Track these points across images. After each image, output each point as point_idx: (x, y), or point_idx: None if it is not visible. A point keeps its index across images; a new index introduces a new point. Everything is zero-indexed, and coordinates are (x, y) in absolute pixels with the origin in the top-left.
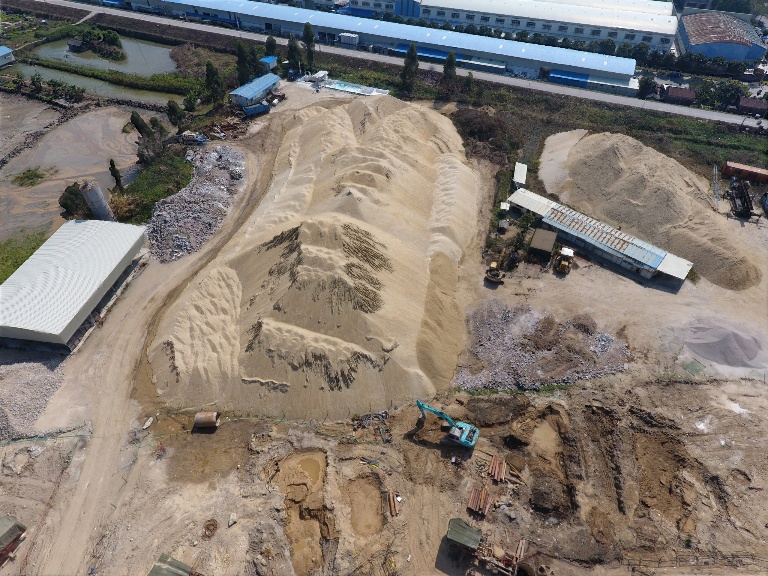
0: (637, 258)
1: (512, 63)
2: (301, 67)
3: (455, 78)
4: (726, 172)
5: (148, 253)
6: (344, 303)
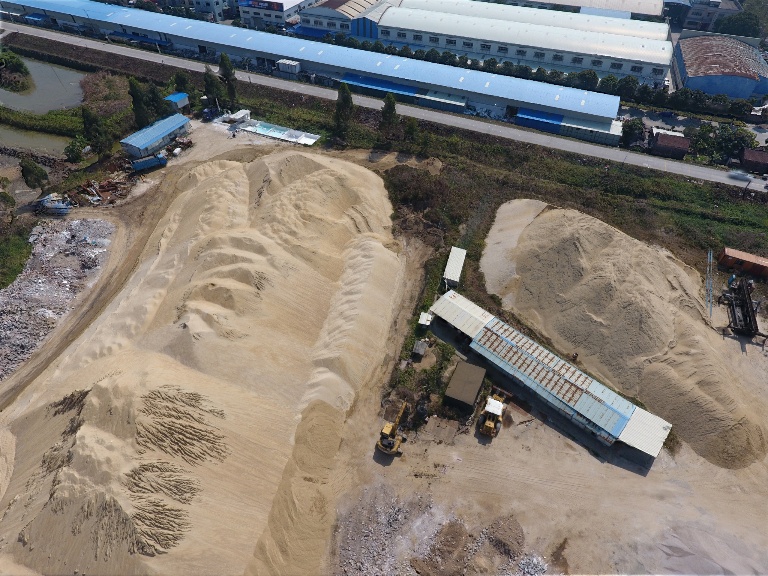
0: (592, 418)
1: (474, 99)
2: (223, 103)
3: (397, 123)
4: (724, 262)
5: None
6: (115, 542)
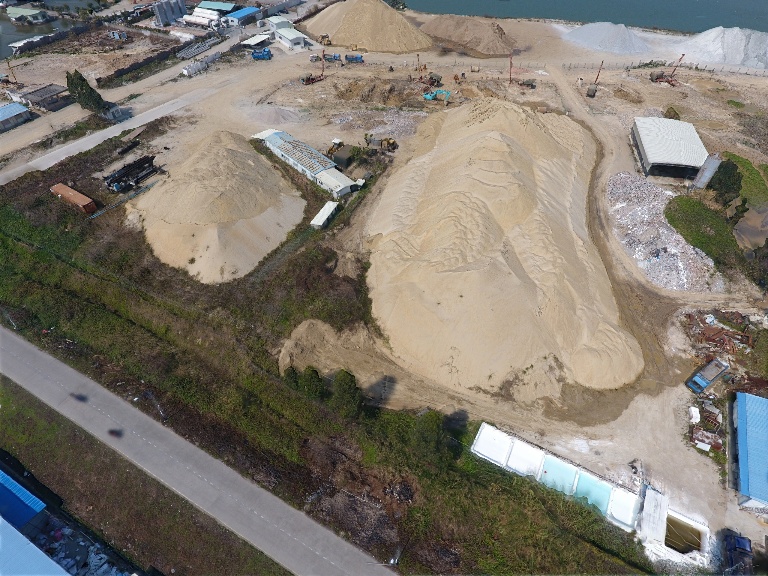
0: (290, 136)
1: None
2: None
3: None
4: None
5: (644, 178)
6: None
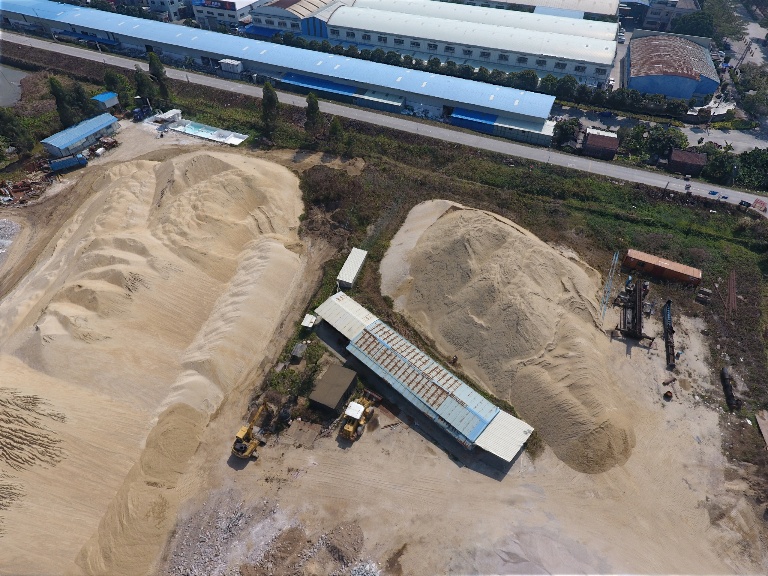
0: (452, 422)
1: (411, 99)
2: (157, 103)
3: (322, 123)
4: (627, 263)
5: None
6: None
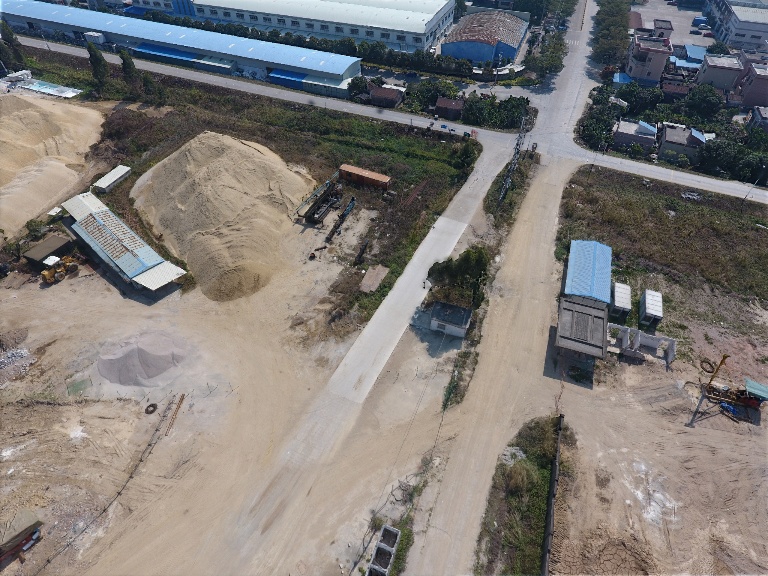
0: (122, 267)
1: (241, 62)
2: (15, 67)
3: (140, 78)
4: (341, 175)
5: None
6: None
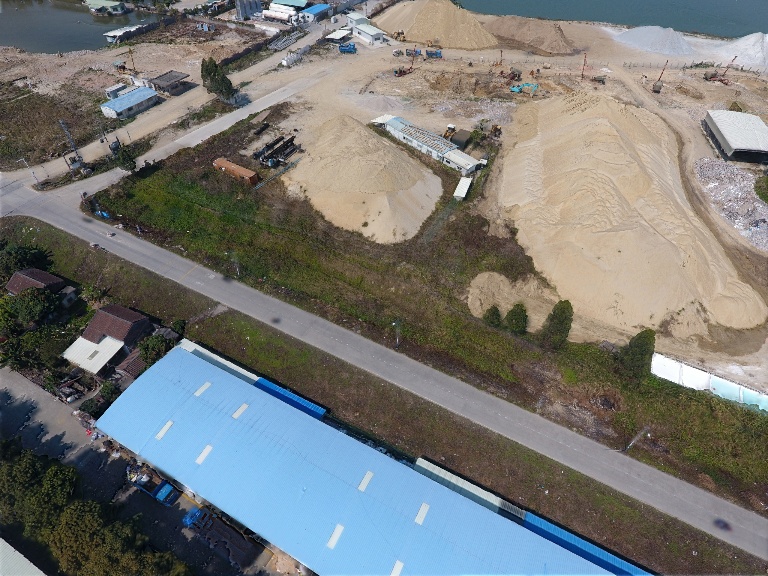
0: None
1: None
2: None
3: None
4: None
5: None
6: None
